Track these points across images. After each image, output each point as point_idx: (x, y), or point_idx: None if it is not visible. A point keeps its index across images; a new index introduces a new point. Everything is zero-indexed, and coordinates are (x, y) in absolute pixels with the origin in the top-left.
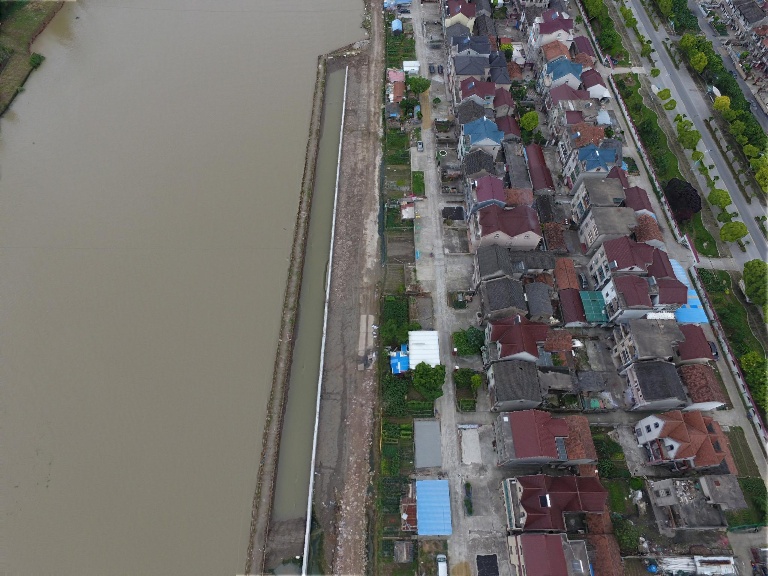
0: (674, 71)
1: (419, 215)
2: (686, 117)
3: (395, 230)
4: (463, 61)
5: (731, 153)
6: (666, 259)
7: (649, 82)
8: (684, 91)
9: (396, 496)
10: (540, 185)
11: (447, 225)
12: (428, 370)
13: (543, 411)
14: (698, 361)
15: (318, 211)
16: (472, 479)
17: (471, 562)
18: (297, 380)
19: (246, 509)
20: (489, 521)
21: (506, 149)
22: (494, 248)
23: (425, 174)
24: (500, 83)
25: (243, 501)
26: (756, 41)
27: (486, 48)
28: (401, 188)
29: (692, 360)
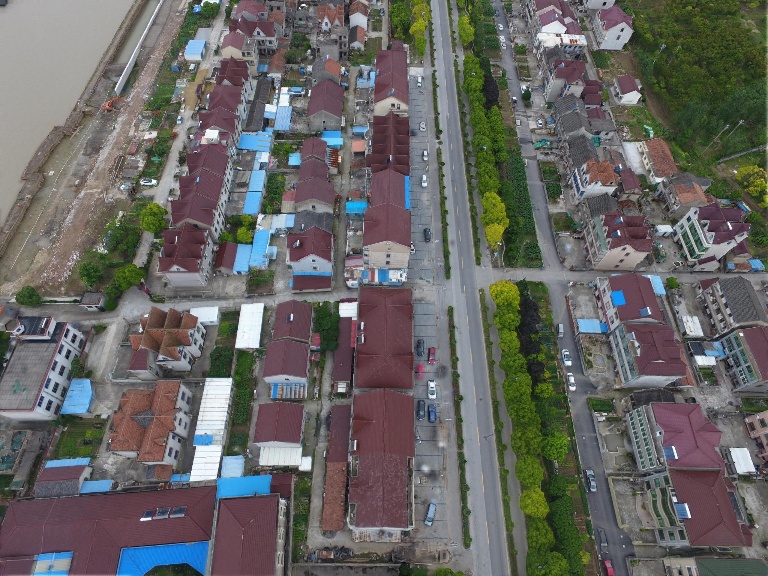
0: None
1: None
2: None
3: None
4: None
5: None
6: None
7: None
8: None
9: None
10: None
11: None
12: (209, 4)
13: (255, 2)
14: None
15: None
16: None
17: (210, 69)
18: (142, 23)
19: (99, 56)
20: None
21: None
22: None
23: None
24: None
25: (98, 54)
26: None
27: None
28: None
29: (356, 1)
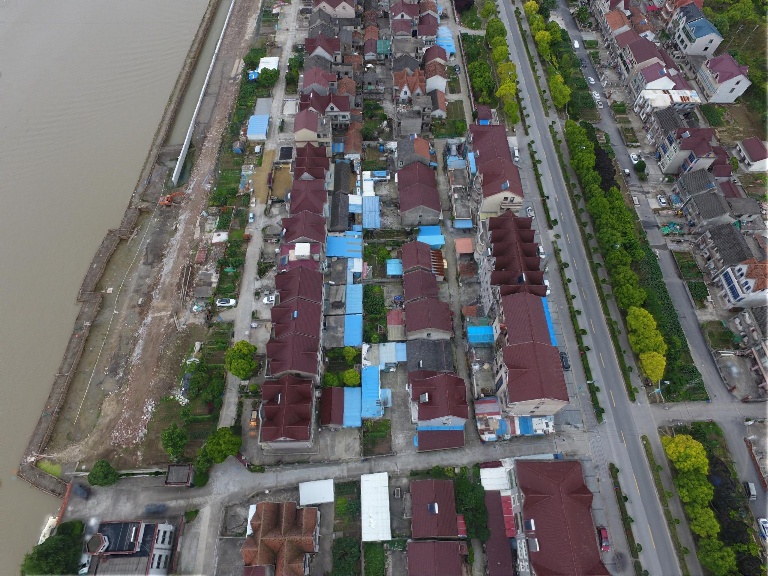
0: None
1: None
2: None
3: (267, 21)
4: None
5: None
6: (434, 20)
7: None
8: None
9: (240, 129)
10: None
11: (301, 15)
12: (268, 71)
13: None
14: (434, 60)
15: (220, 18)
16: (287, 120)
17: (277, 150)
18: (192, 93)
19: (150, 137)
20: (292, 135)
21: None
22: (319, 11)
23: None
24: None
25: (149, 134)
26: None
27: None
28: (276, 2)
29: (432, 61)
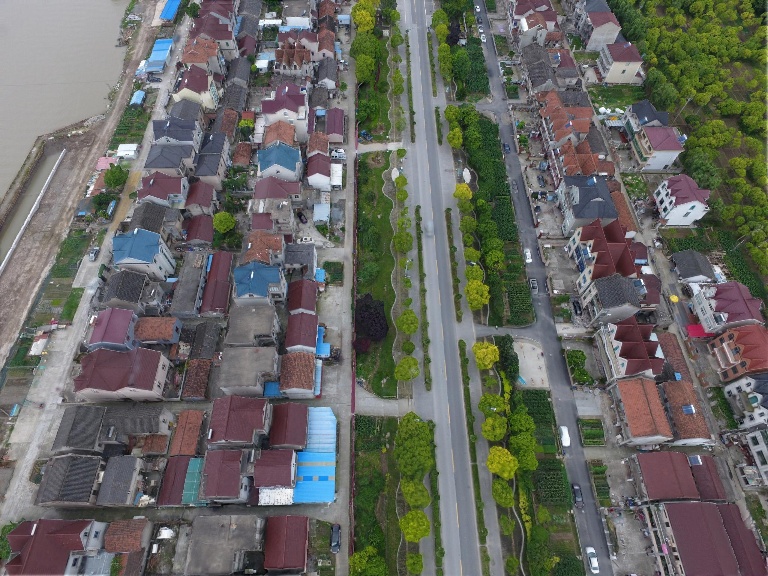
0: (435, 147)
1: (47, 351)
2: (427, 206)
3: (19, 369)
4: (156, 151)
5: (463, 253)
6: (300, 416)
7: (400, 162)
8: (437, 172)
9: None
10: (206, 307)
11: (76, 363)
12: None
13: None
14: (276, 572)
15: None
16: None
17: None
18: None
19: None
20: None
21: (185, 259)
22: (76, 411)
23: (85, 291)
24: (203, 174)
25: None
26: (538, 108)
27: (187, 134)
28: (53, 310)
29: (271, 570)
